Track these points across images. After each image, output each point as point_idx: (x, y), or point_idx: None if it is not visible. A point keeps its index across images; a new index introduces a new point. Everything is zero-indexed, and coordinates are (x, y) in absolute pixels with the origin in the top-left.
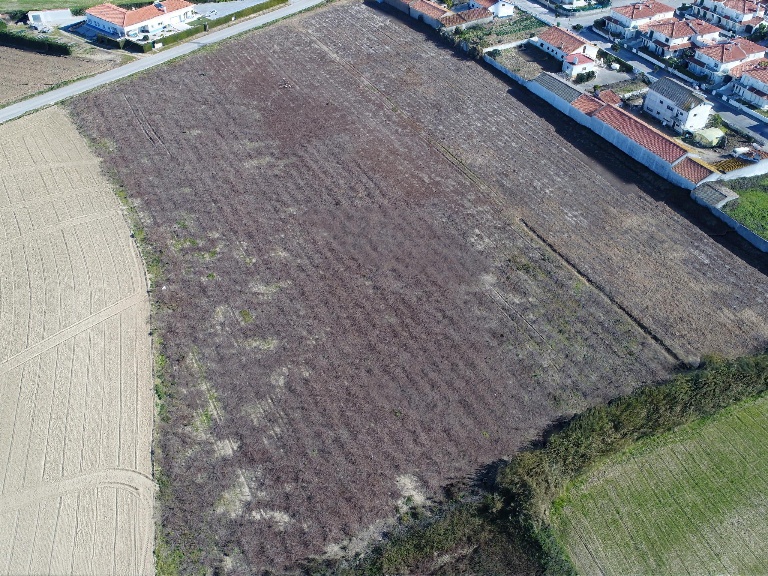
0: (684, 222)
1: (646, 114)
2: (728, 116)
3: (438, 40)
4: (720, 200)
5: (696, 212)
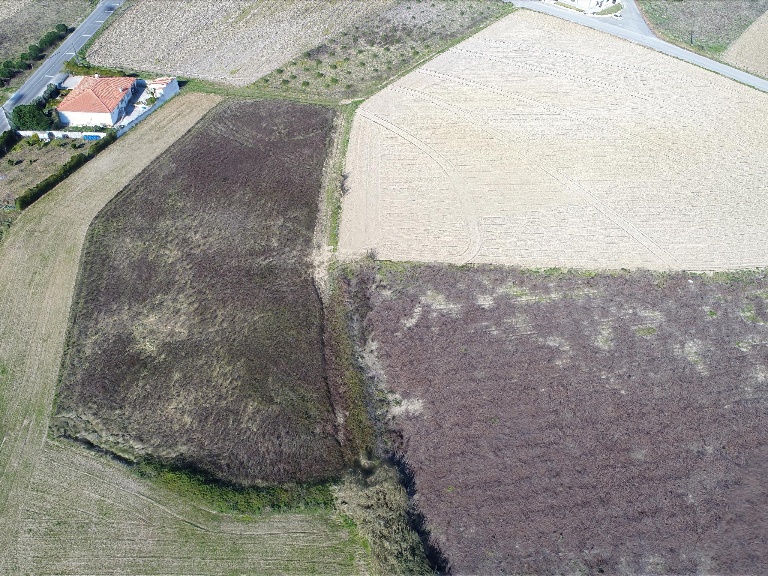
0: None
1: None
2: None
3: None
4: None
5: None
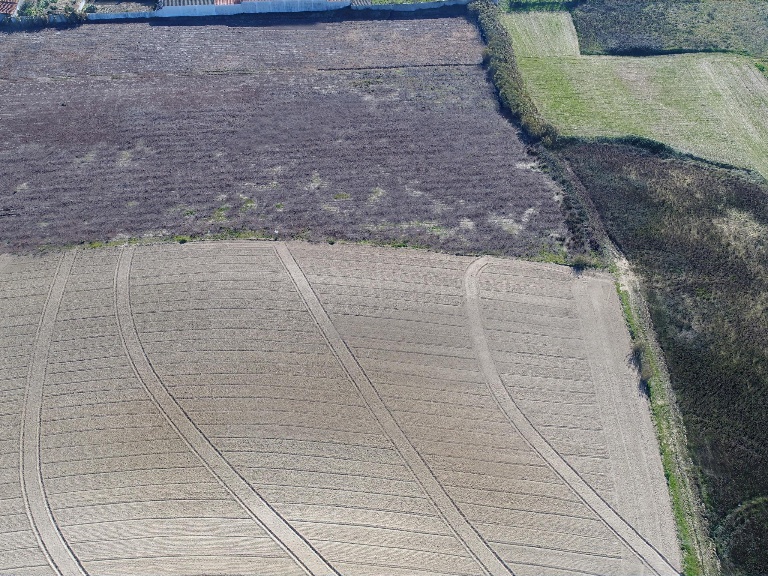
0: (369, 22)
1: None
2: None
3: (19, 29)
4: None
5: (365, 15)
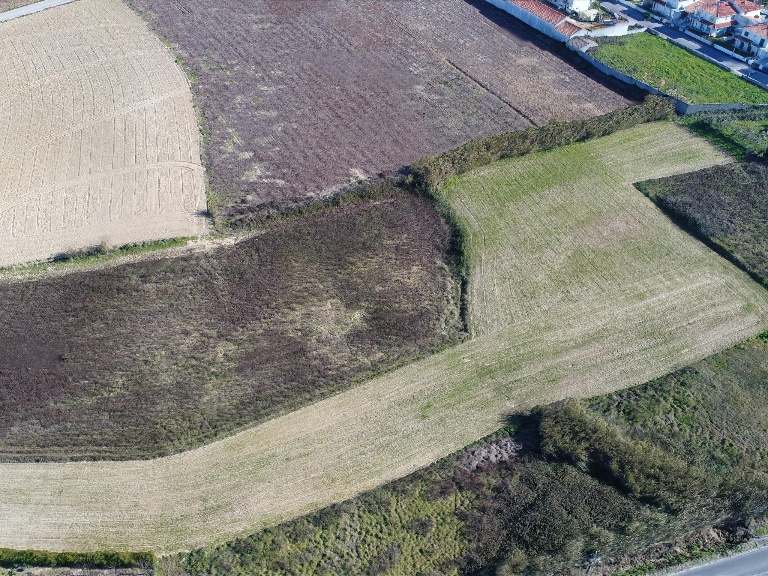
0: (559, 61)
1: (548, 3)
2: (608, 5)
3: None
4: (584, 46)
5: (568, 55)
